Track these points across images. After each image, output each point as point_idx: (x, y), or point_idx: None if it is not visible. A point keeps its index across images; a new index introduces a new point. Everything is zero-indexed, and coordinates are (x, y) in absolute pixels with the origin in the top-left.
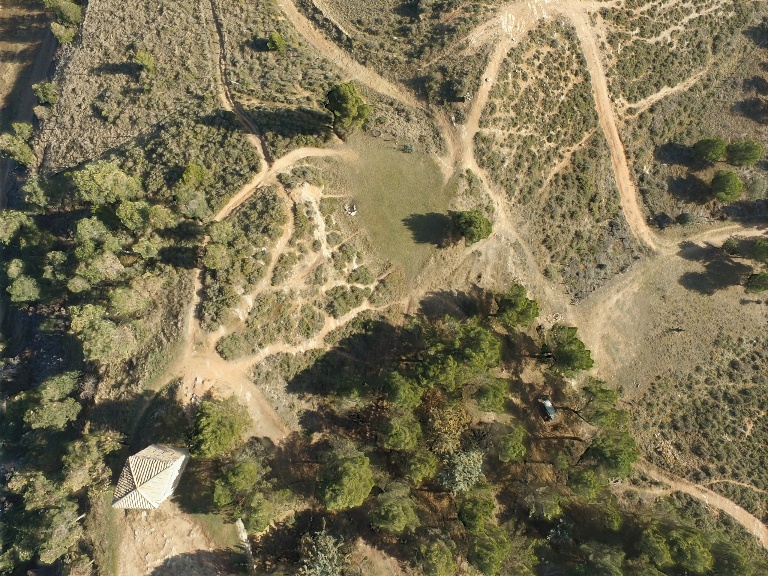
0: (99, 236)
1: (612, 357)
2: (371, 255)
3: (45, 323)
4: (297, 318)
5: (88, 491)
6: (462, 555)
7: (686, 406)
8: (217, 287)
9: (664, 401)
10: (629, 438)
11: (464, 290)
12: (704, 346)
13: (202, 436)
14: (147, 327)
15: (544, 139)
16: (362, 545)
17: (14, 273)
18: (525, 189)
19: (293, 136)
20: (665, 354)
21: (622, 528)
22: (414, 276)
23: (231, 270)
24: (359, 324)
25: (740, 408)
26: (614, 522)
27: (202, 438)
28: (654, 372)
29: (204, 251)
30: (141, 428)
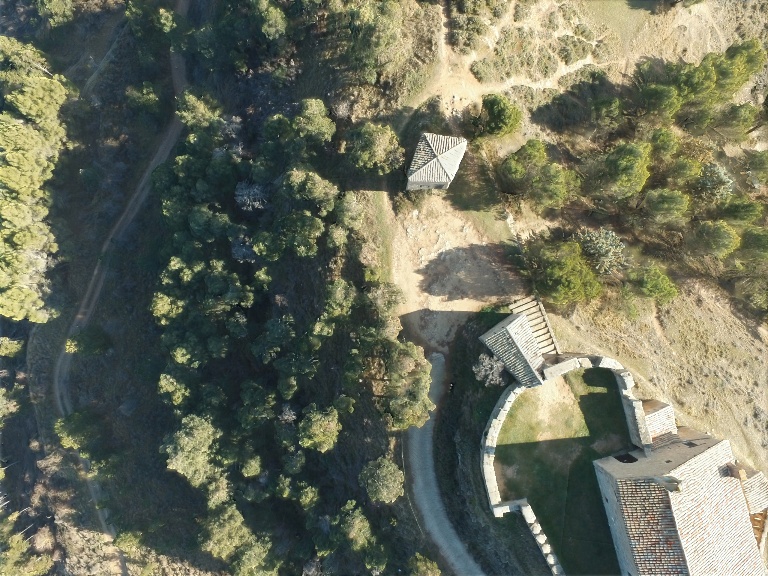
0: None
1: None
2: (587, 19)
3: (279, 69)
4: (536, 56)
5: (378, 171)
6: (699, 284)
7: None
8: (465, 17)
9: None
10: None
11: (672, 61)
12: None
13: (503, 105)
14: (400, 52)
15: None
16: None
17: (265, 4)
18: None
19: None
20: None
21: None
22: (630, 39)
23: (478, 2)
24: (587, 73)
25: None
26: None
27: (502, 107)
28: None
29: None
30: (403, 140)
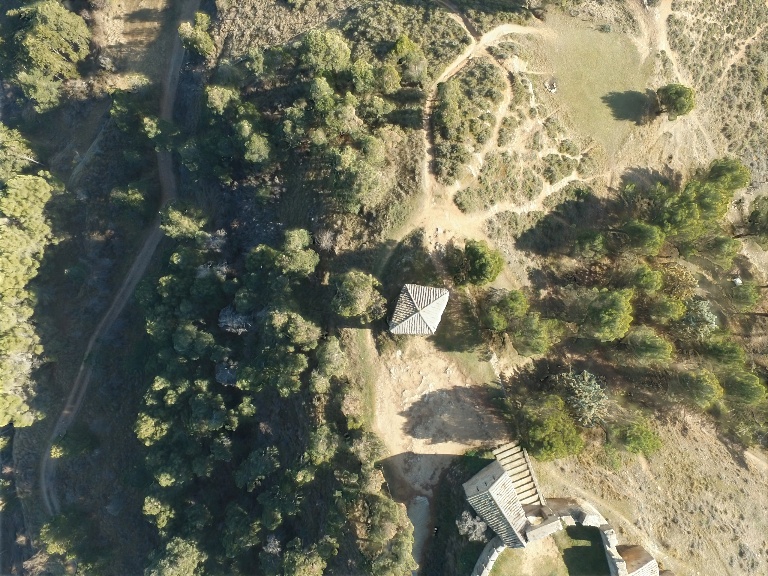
0: (330, 96)
1: None
2: (572, 131)
3: (263, 189)
4: (520, 180)
5: (360, 320)
6: (685, 409)
7: None
8: (449, 145)
9: None
10: None
11: (658, 169)
12: None
13: (484, 260)
14: None
15: (724, 29)
16: None
17: (247, 131)
18: (707, 77)
19: (496, 13)
20: None
21: None
22: (615, 151)
23: (462, 129)
24: (572, 191)
25: None
26: None
27: (484, 262)
28: None
29: (427, 115)
30: (386, 275)
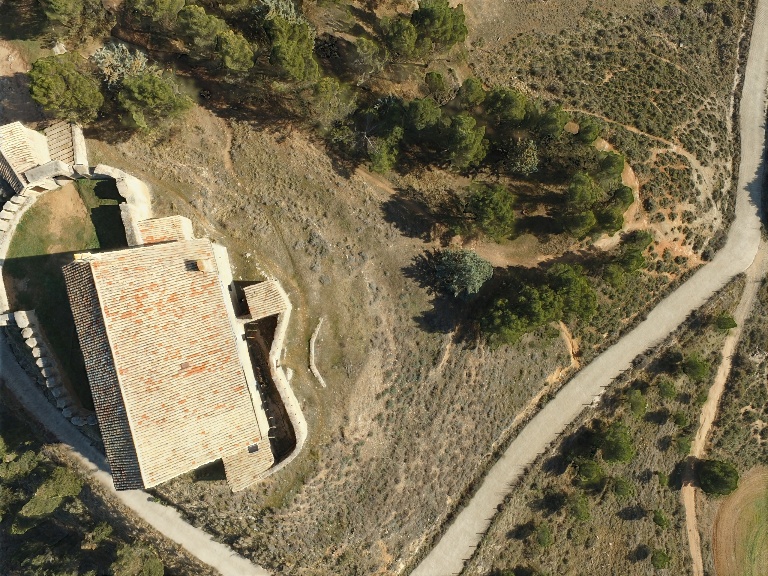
0: None
1: (474, 13)
2: None
3: None
4: None
5: None
6: (292, 125)
7: (546, 58)
8: None
9: (524, 53)
10: (462, 24)
11: None
12: (571, 16)
13: None
14: None
15: None
16: (188, 100)
17: None
18: None
19: None
20: (530, 17)
21: (450, 100)
22: None
23: None
24: None
25: (602, 64)
26: (433, 73)
27: None
28: (517, 30)
29: None
30: None
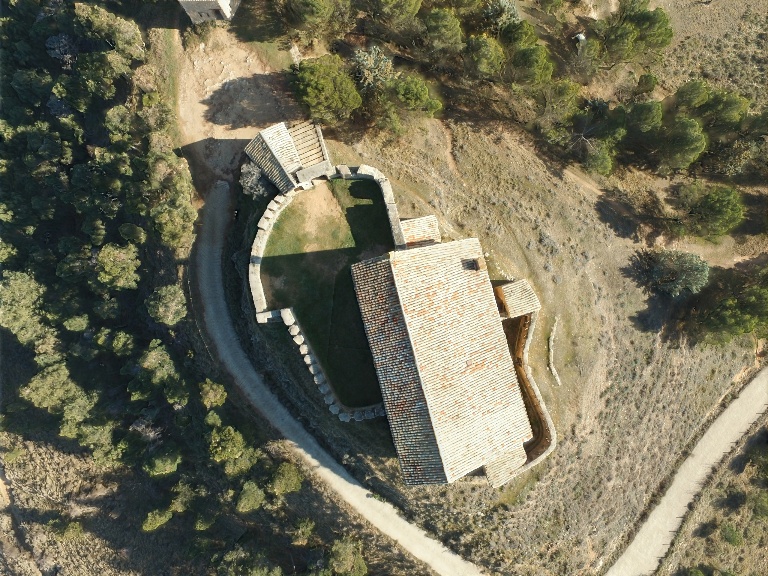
0: None
1: None
2: None
3: None
4: None
5: None
6: (503, 126)
7: (715, 61)
8: None
9: (694, 56)
10: None
11: None
12: (732, 19)
13: None
14: None
15: None
16: None
17: None
18: None
19: None
20: (694, 21)
21: None
22: None
23: None
24: None
25: None
26: None
27: None
28: (684, 33)
29: None
30: None
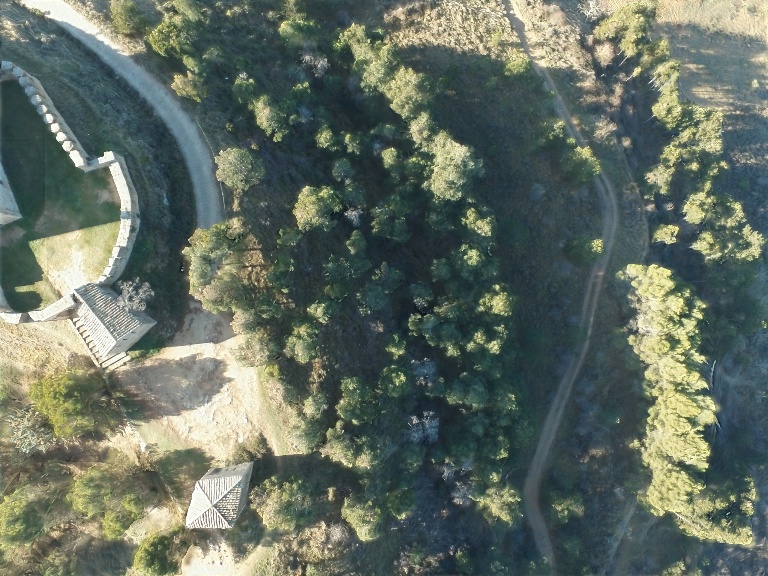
0: None
1: None
2: None
3: None
4: None
5: None
6: None
7: None
8: None
9: None
10: None
11: None
12: None
13: (149, 571)
14: None
15: None
16: None
17: None
18: None
19: None
20: None
21: None
22: None
23: None
24: None
25: None
26: None
27: (150, 568)
28: None
29: None
30: None
